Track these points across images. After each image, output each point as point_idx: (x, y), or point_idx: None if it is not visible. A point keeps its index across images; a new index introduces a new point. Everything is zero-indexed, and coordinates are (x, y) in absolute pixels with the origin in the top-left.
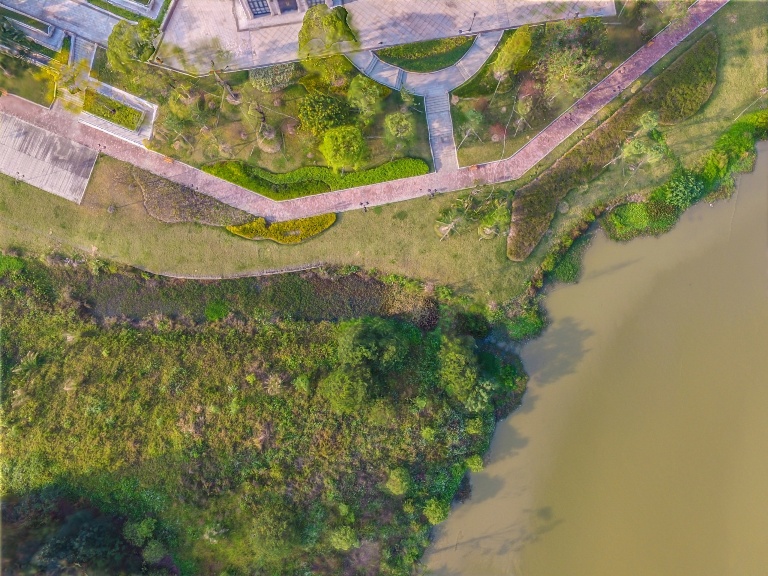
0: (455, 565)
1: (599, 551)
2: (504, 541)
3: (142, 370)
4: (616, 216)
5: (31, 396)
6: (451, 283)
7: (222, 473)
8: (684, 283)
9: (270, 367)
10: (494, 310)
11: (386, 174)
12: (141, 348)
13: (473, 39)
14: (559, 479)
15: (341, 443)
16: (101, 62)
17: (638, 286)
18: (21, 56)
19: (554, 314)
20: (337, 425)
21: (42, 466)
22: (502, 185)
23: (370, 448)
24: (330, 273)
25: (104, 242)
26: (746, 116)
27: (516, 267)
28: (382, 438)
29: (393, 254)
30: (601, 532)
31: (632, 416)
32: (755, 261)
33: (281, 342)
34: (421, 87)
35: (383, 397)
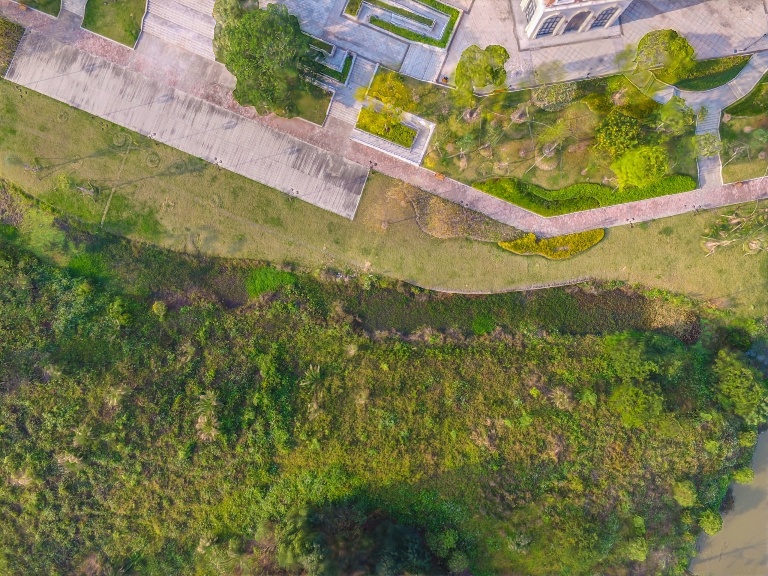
0: (720, 575)
1: None
2: (767, 551)
3: (425, 383)
4: None
5: (322, 409)
6: (714, 298)
7: (522, 485)
8: None
9: (549, 381)
10: (758, 324)
11: (655, 191)
12: (419, 362)
13: (748, 58)
14: None
15: (633, 456)
16: (380, 81)
17: None
18: (301, 75)
19: None
20: (627, 438)
21: (345, 478)
22: (765, 201)
23: (660, 461)
24: (595, 288)
25: (378, 257)
26: None
27: None
28: (670, 451)
29: (660, 269)
30: None
31: None
32: None
33: (553, 356)
34: (694, 105)
35: None
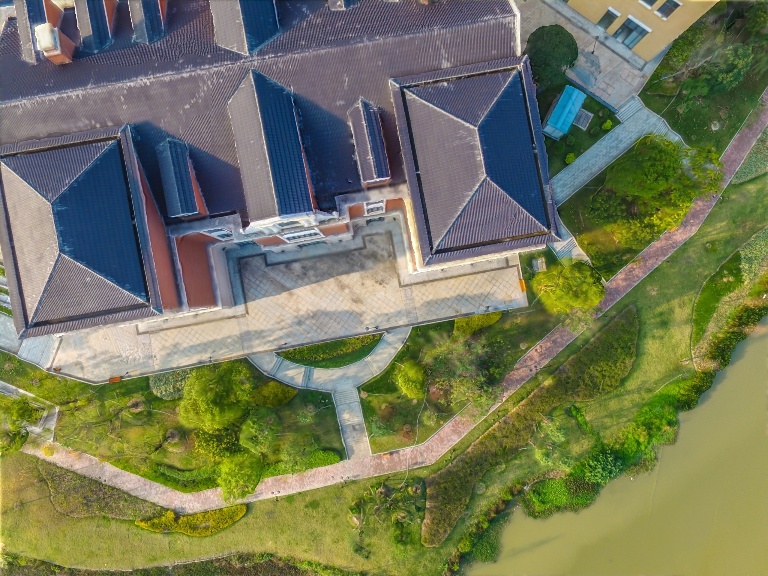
0: None
1: None
2: None
3: None
4: (534, 494)
5: None
6: (366, 569)
7: None
8: (604, 559)
9: None
10: None
11: None
12: None
13: (380, 336)
14: None
15: None
16: None
17: (557, 562)
18: None
19: None
20: None
21: None
22: (416, 471)
23: None
24: (243, 562)
25: (11, 539)
26: (668, 387)
27: (431, 552)
28: None
29: (305, 544)
30: None
31: None
32: (676, 535)
33: None
34: (329, 382)
35: None
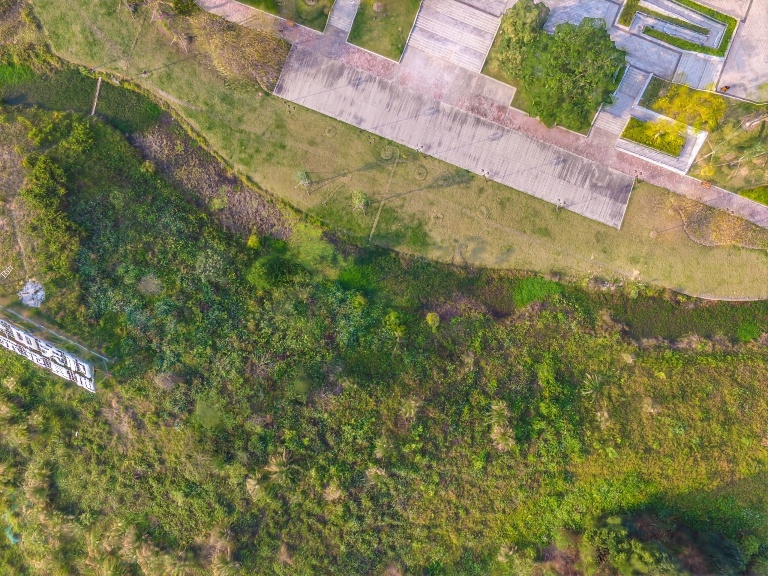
0: None
1: None
2: None
3: (705, 391)
4: None
5: None
6: None
7: None
8: None
9: None
10: None
11: None
12: (693, 369)
13: None
14: None
15: None
16: (652, 91)
17: None
18: None
19: None
20: None
21: (644, 486)
22: None
23: None
24: None
25: (647, 266)
26: None
27: None
28: None
29: None
30: None
31: None
32: None
33: None
34: None
35: None
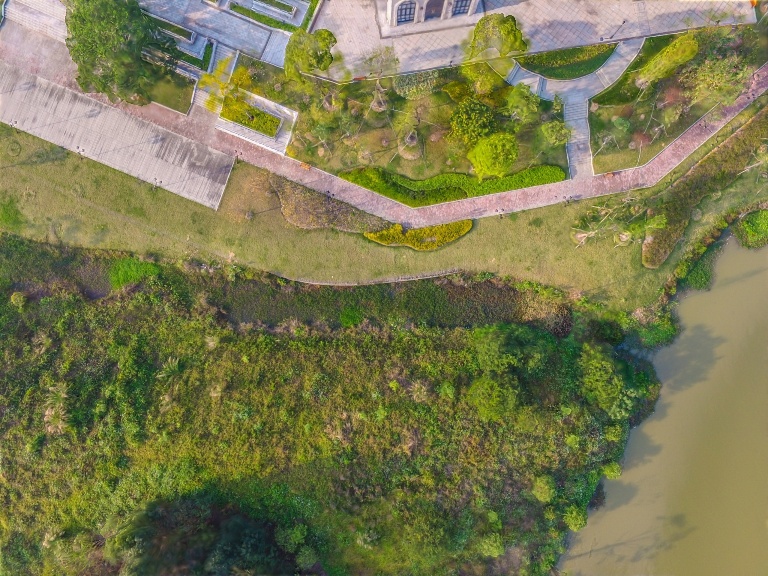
0: (589, 572)
1: (733, 559)
2: (638, 548)
3: (284, 376)
4: (748, 223)
5: (177, 402)
6: (585, 290)
7: (373, 480)
8: None
9: (411, 374)
10: (629, 317)
11: (523, 181)
12: (280, 354)
13: (614, 47)
14: (692, 486)
15: (489, 450)
16: (242, 69)
17: None
18: (162, 63)
19: (686, 321)
20: (484, 432)
21: (193, 472)
22: (637, 192)
23: (517, 455)
24: (465, 280)
25: (242, 248)
26: None
27: (650, 274)
28: (528, 445)
29: (529, 261)
30: (735, 540)
31: (765, 424)
32: None
33: (419, 348)
34: (561, 94)
35: (527, 404)
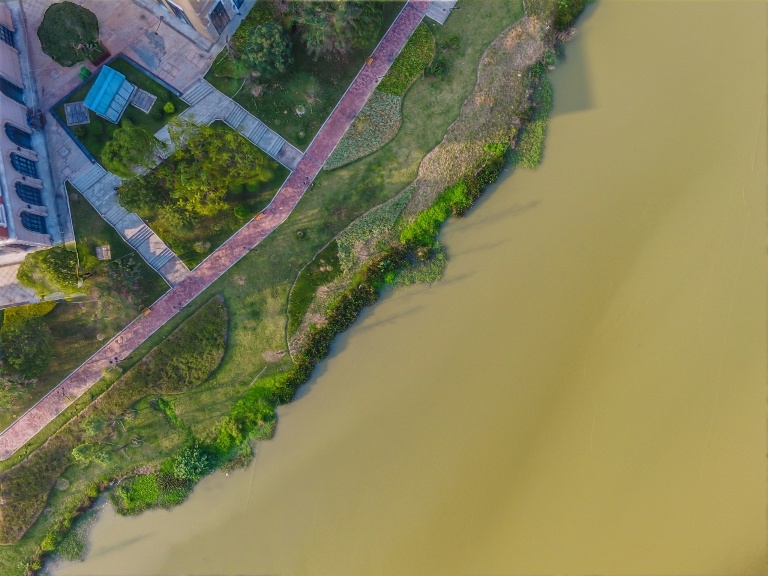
0: None
1: None
2: None
3: None
4: (122, 490)
5: None
6: None
7: None
8: (197, 558)
9: None
10: None
11: None
12: None
13: None
14: None
15: None
16: None
17: (150, 561)
18: None
19: None
20: None
21: None
22: None
23: None
24: None
25: None
26: (264, 380)
27: (8, 551)
28: None
29: None
30: None
31: None
32: (273, 533)
33: None
34: None
35: None
